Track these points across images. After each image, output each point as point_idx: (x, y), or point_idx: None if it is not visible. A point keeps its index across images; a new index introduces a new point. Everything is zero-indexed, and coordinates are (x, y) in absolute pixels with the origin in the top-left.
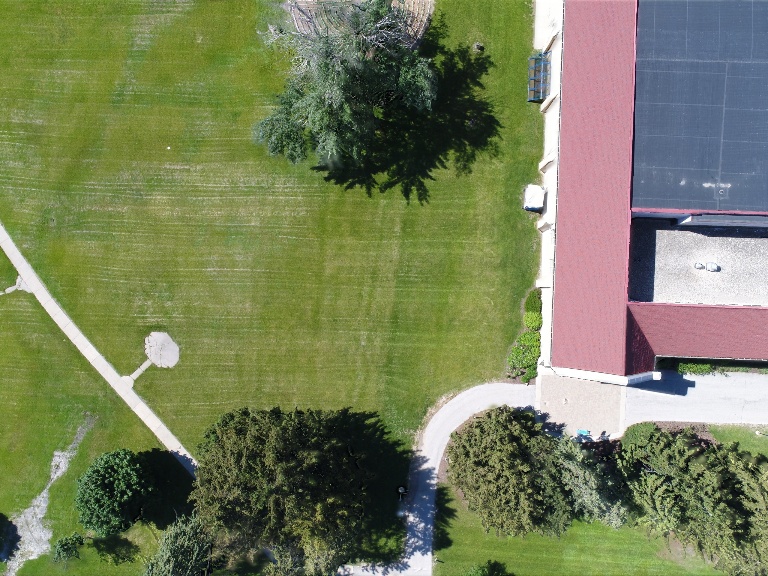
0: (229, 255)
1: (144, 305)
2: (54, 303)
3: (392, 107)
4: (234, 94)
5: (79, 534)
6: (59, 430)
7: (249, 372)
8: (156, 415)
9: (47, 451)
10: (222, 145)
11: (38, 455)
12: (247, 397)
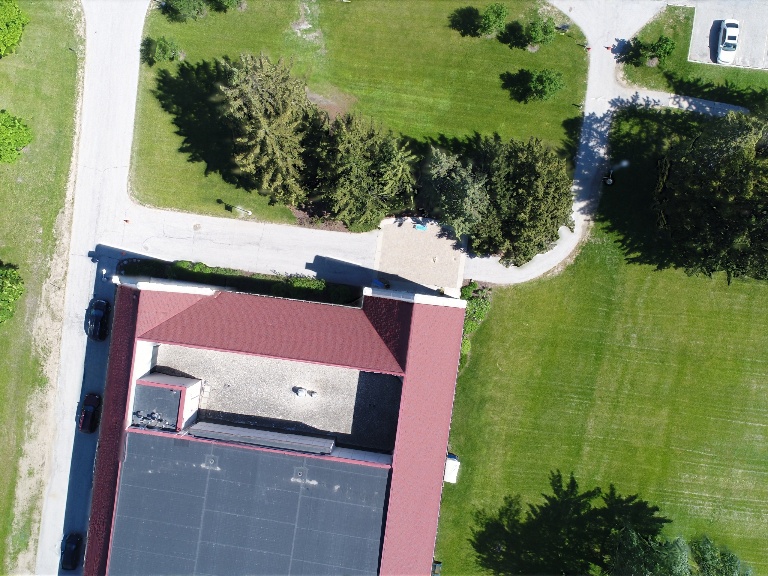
0: None
1: None
2: None
3: (582, 575)
4: None
5: None
6: None
7: (760, 317)
8: None
9: None
10: (765, 557)
11: None
12: (765, 291)
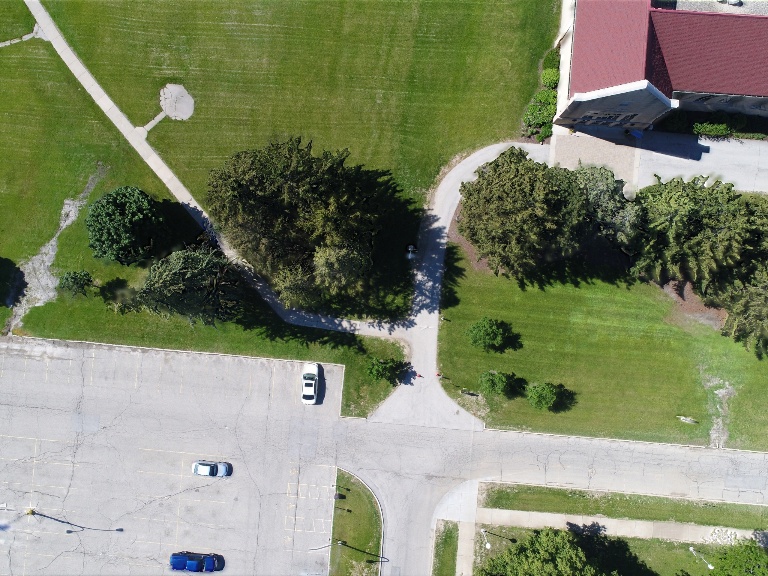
0: (248, 10)
1: (161, 57)
2: (71, 52)
3: None
4: None
5: (87, 272)
6: (70, 178)
7: (263, 127)
8: (168, 167)
9: (58, 199)
10: None
11: (48, 203)
12: None
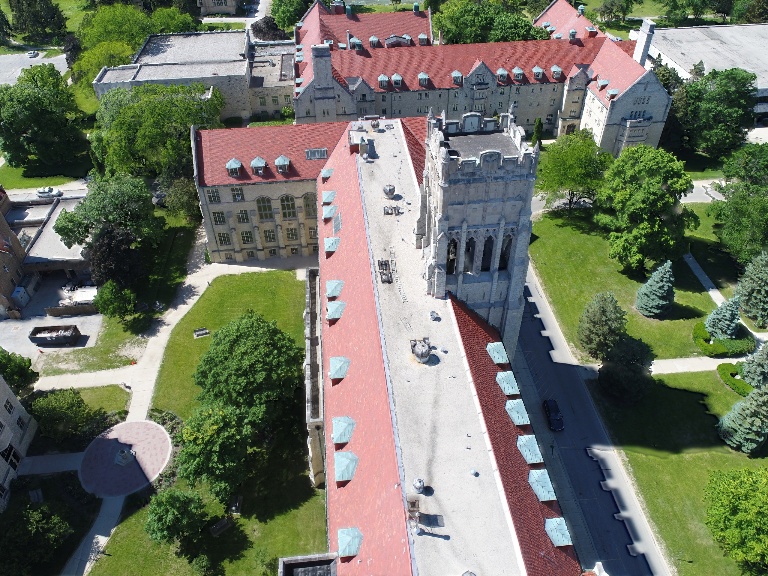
0: None
1: None
2: None
3: None
4: (60, 6)
5: None
6: None
7: None
8: None
9: None
10: None
11: None
12: None
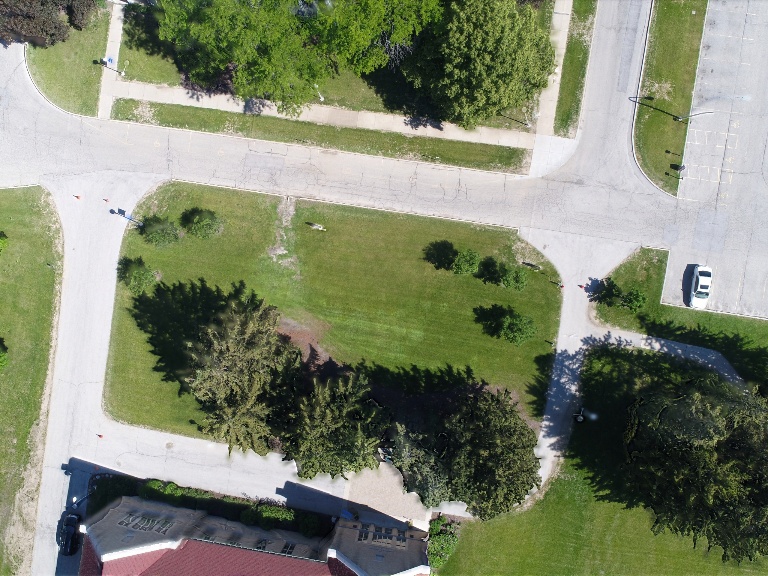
0: None
1: None
2: None
3: None
4: None
5: None
6: None
7: None
8: None
9: None
10: None
11: None
12: None
